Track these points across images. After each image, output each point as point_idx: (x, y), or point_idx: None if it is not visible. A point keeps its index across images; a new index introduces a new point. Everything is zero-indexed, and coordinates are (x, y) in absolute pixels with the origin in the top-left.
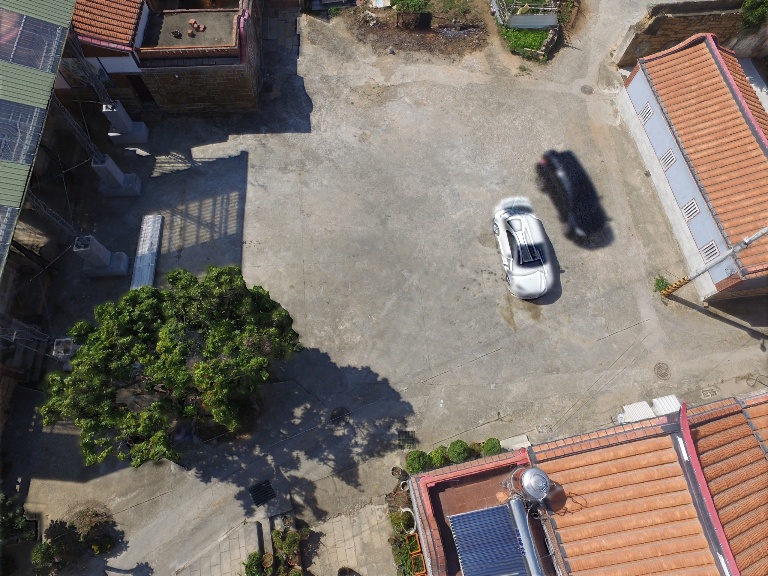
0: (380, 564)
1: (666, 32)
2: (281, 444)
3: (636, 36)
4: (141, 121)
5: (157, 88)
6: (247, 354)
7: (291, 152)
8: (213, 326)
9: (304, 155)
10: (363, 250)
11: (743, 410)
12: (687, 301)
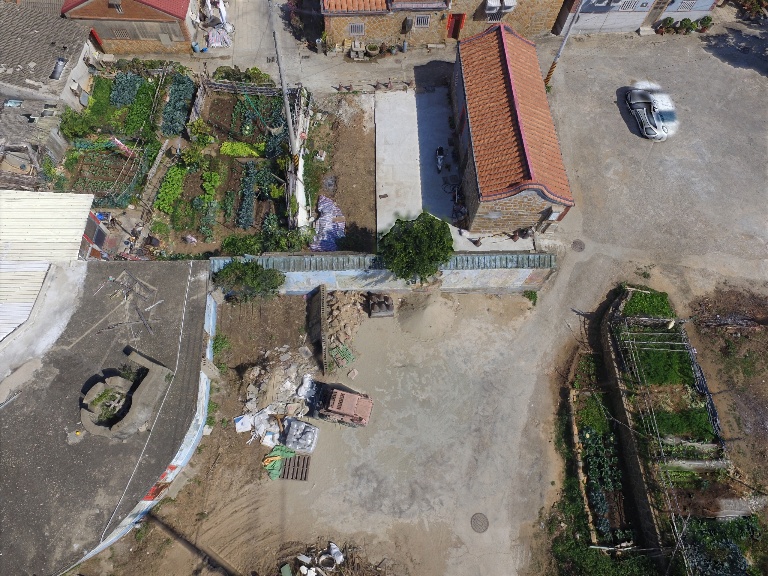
0: None
1: None
2: None
3: None
4: None
5: None
6: None
7: None
8: None
9: None
10: (759, 124)
11: None
12: None
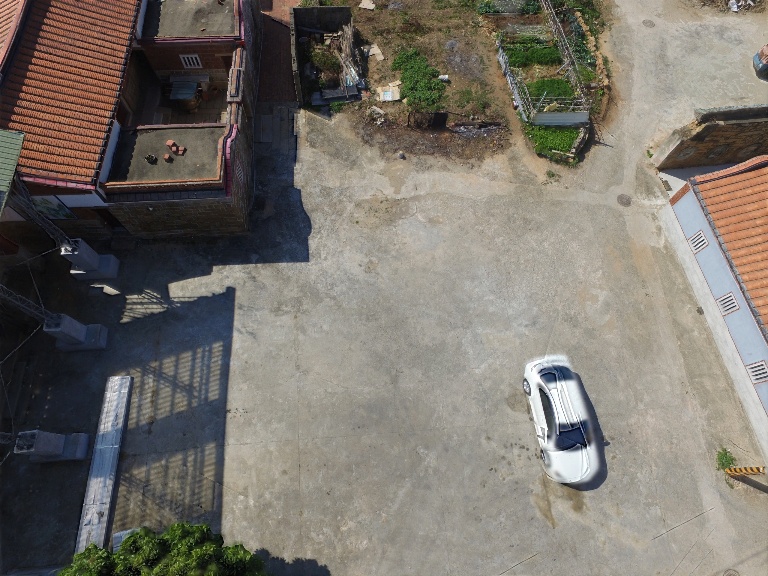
0: None
1: (715, 138)
2: None
3: (681, 142)
4: (110, 252)
5: (128, 219)
6: None
7: (286, 287)
8: None
9: (301, 291)
10: (370, 419)
11: None
12: (756, 482)
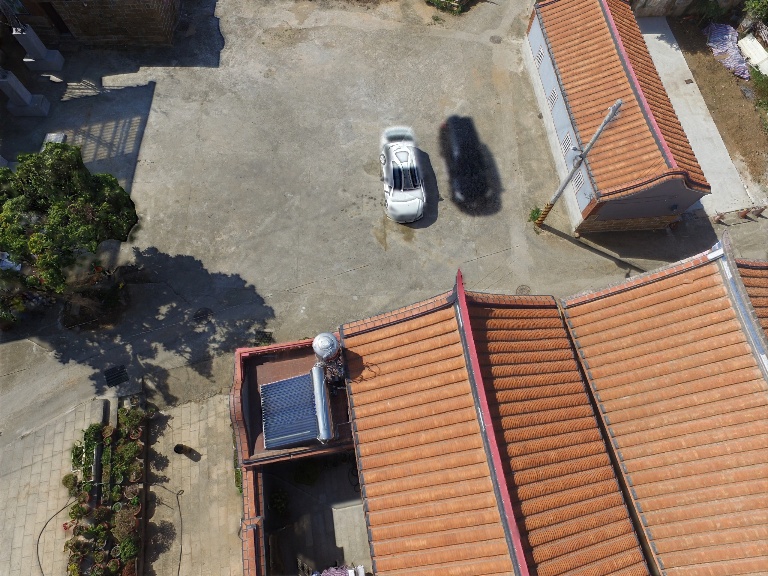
0: (220, 446)
1: None
2: (142, 335)
3: None
4: (57, 50)
5: (69, 17)
6: (76, 223)
7: (197, 84)
8: (52, 200)
9: (209, 87)
10: (251, 172)
11: (564, 310)
12: (559, 231)
